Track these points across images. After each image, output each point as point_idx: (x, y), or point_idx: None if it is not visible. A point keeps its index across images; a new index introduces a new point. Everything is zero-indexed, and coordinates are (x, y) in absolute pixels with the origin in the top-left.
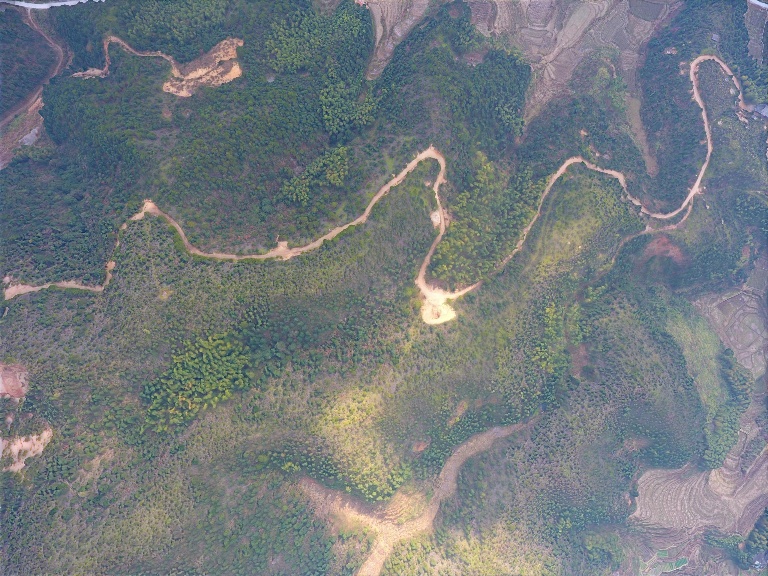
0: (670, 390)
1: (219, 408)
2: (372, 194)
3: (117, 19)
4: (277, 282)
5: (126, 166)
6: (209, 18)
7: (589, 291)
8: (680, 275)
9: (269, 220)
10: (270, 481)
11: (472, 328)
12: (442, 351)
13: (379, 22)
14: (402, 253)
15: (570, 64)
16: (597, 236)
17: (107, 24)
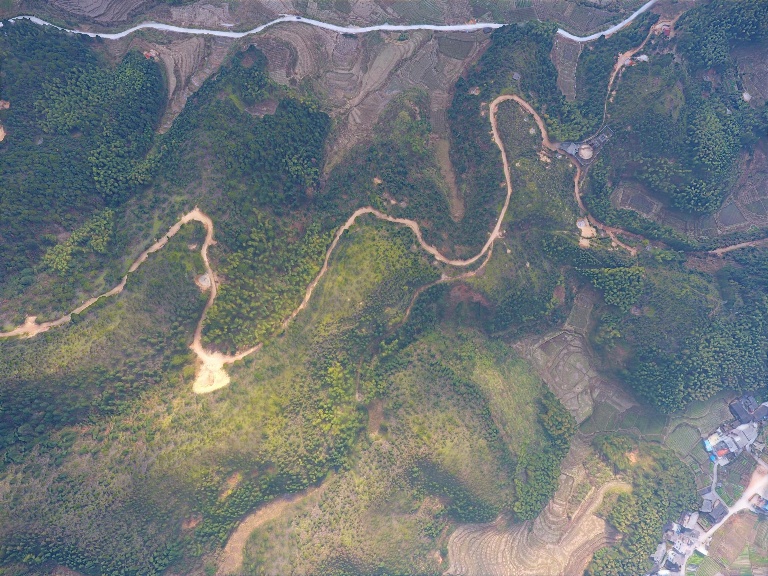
0: (466, 445)
1: None
2: (130, 261)
3: None
4: (11, 364)
5: None
6: None
7: (383, 345)
8: (489, 320)
9: (27, 292)
10: (9, 575)
11: (243, 395)
12: (205, 423)
13: (172, 73)
14: (164, 321)
15: (376, 107)
16: (378, 291)
17: None
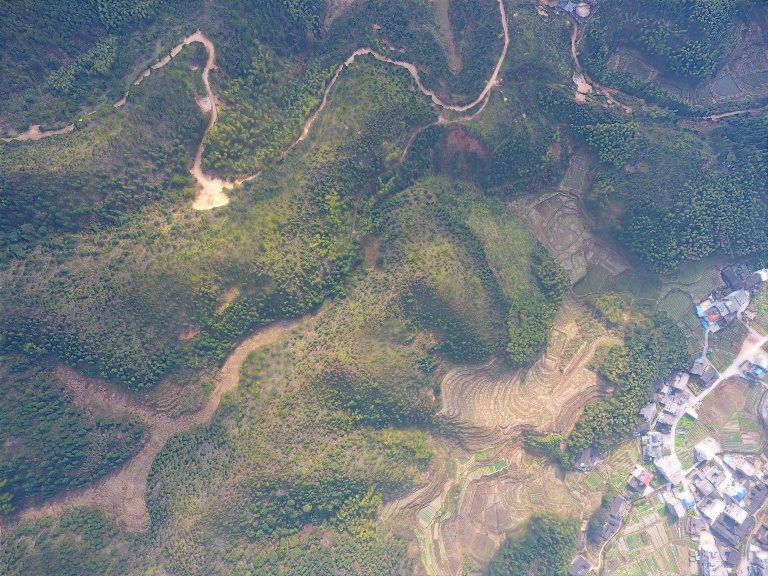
0: (460, 278)
1: None
2: (133, 78)
3: None
4: (15, 159)
5: None
6: None
7: (380, 182)
8: (485, 171)
9: (31, 109)
10: (10, 363)
11: (242, 213)
12: (204, 233)
13: None
14: (165, 137)
15: None
16: (376, 121)
17: None
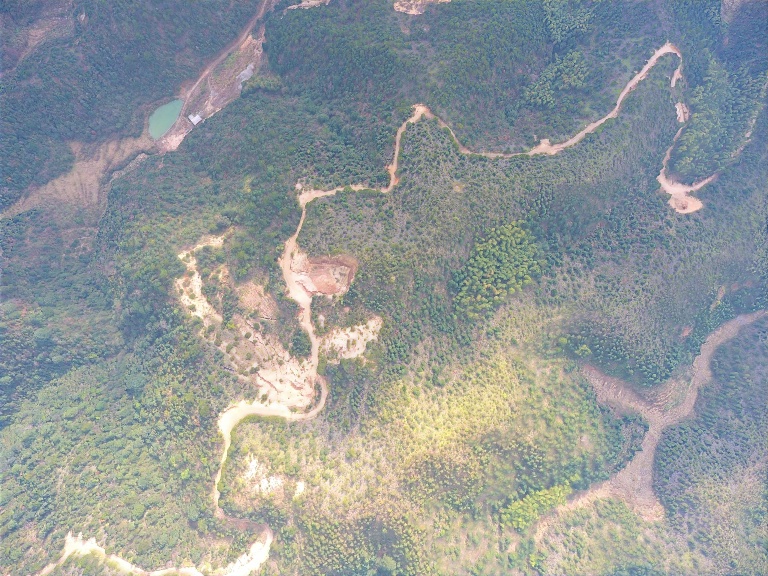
0: None
1: (520, 293)
2: (620, 90)
3: None
4: (557, 172)
5: (384, 77)
6: None
7: None
8: None
9: (518, 124)
10: (567, 364)
11: (724, 214)
12: (705, 235)
13: None
14: (653, 145)
15: None
16: None
17: None
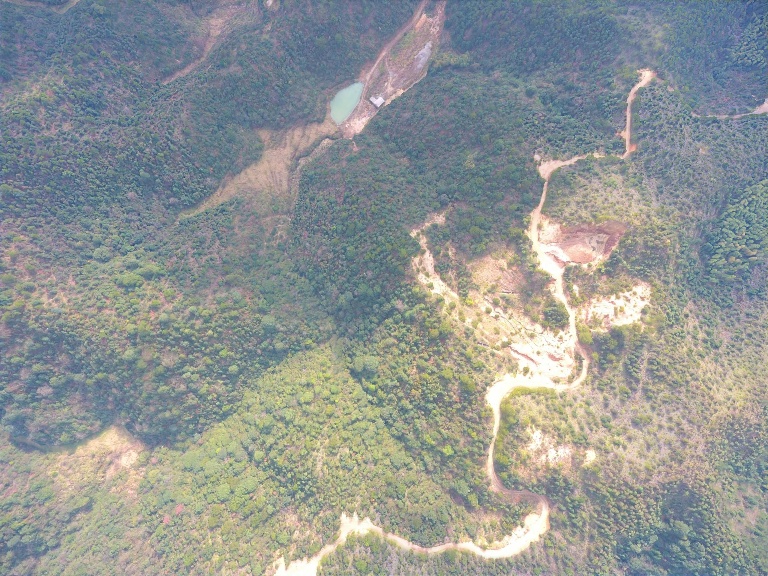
0: None
1: None
2: None
3: None
4: None
5: (599, 45)
6: None
7: None
8: None
9: (729, 86)
10: None
11: None
12: None
13: None
14: None
15: None
16: None
17: None
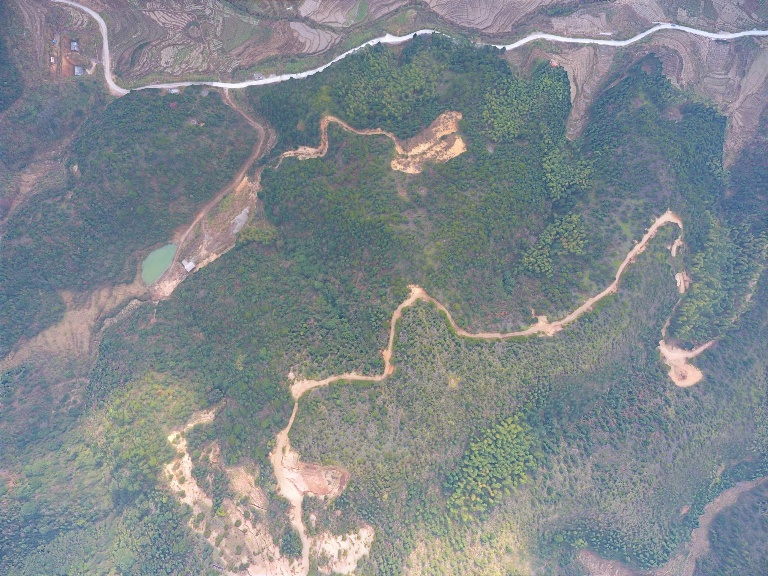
0: None
1: None
2: (619, 262)
3: (332, 98)
4: (555, 361)
5: (380, 251)
6: (417, 91)
7: None
8: None
9: (515, 293)
10: (562, 559)
11: (724, 388)
12: (704, 415)
13: (572, 82)
14: (652, 319)
15: (755, 110)
16: None
17: (324, 104)
